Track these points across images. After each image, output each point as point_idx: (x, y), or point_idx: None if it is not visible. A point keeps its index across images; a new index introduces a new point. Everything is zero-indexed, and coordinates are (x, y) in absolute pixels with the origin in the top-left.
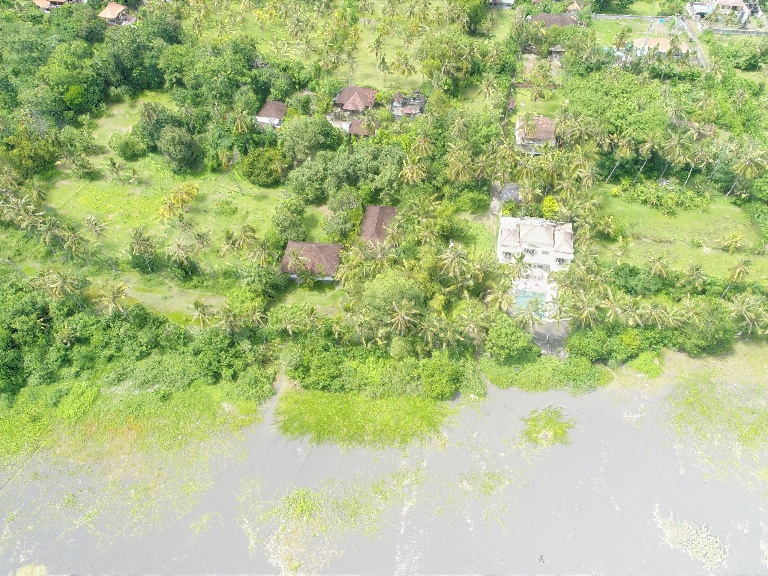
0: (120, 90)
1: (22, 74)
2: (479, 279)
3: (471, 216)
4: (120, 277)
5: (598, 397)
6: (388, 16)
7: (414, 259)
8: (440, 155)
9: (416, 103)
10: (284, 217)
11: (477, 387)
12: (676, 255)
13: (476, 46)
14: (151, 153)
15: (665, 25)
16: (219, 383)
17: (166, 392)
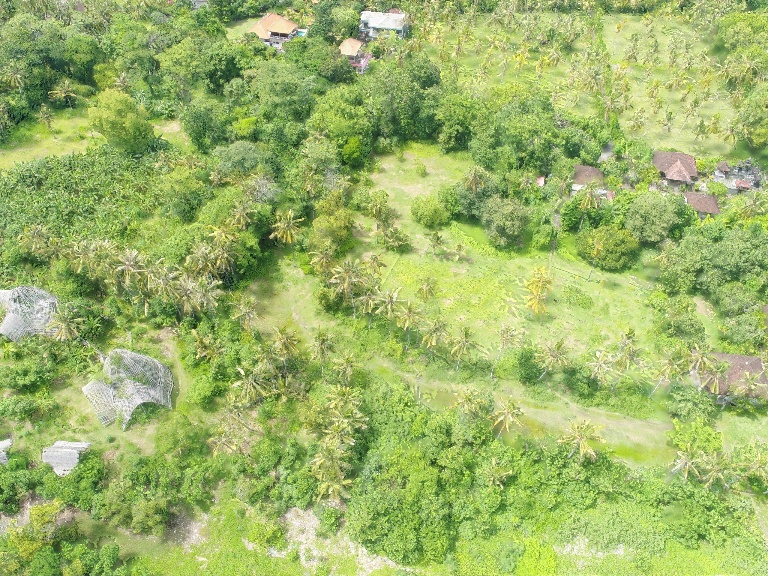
0: (389, 141)
1: (278, 119)
2: None
3: None
4: (499, 386)
5: None
6: None
7: None
8: None
9: (741, 174)
10: (691, 322)
11: None
12: None
13: None
14: (454, 221)
15: None
16: (700, 546)
17: None
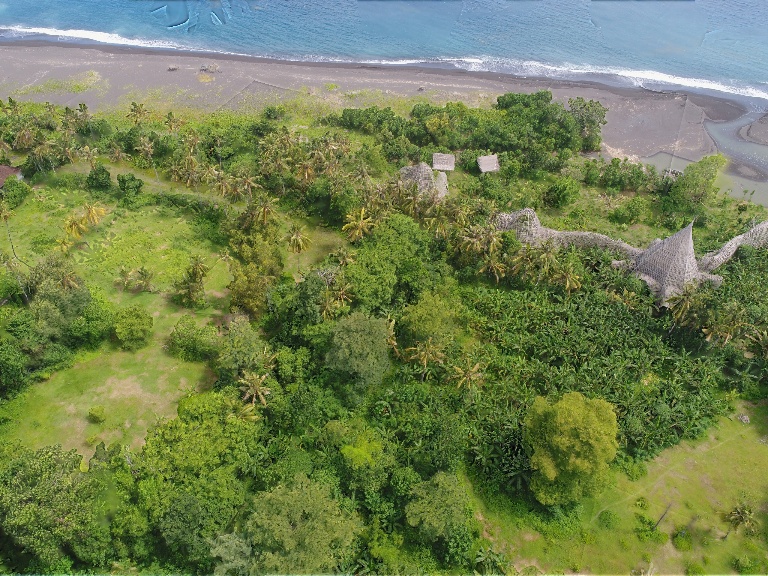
0: None
1: None
2: None
3: None
4: None
5: None
6: None
7: None
8: None
9: None
10: None
11: None
12: None
13: None
14: None
15: None
16: None
17: None
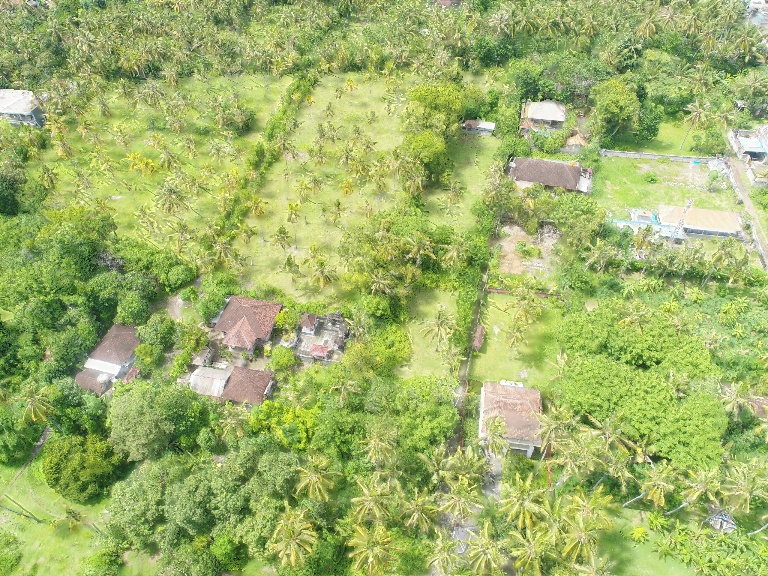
0: None
1: None
2: None
3: None
4: None
5: None
6: None
7: None
8: None
9: (336, 328)
10: None
11: None
12: None
13: None
14: None
15: (701, 170)
16: None
17: None
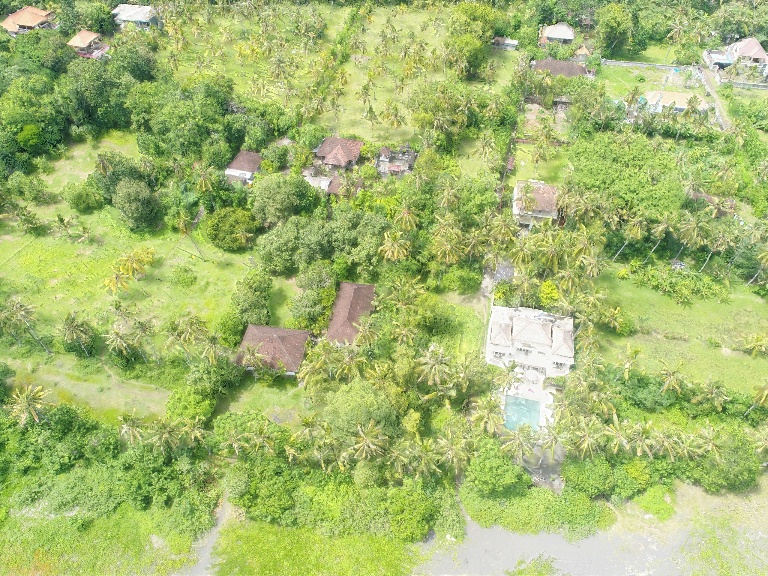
0: (82, 129)
1: None
2: (463, 388)
3: (459, 297)
4: (53, 360)
5: (598, 545)
6: (380, 56)
7: (389, 359)
8: (428, 223)
9: (405, 158)
10: (244, 297)
11: (454, 527)
12: (691, 356)
13: (474, 95)
14: (108, 205)
15: (680, 75)
16: (150, 508)
17: (85, 520)
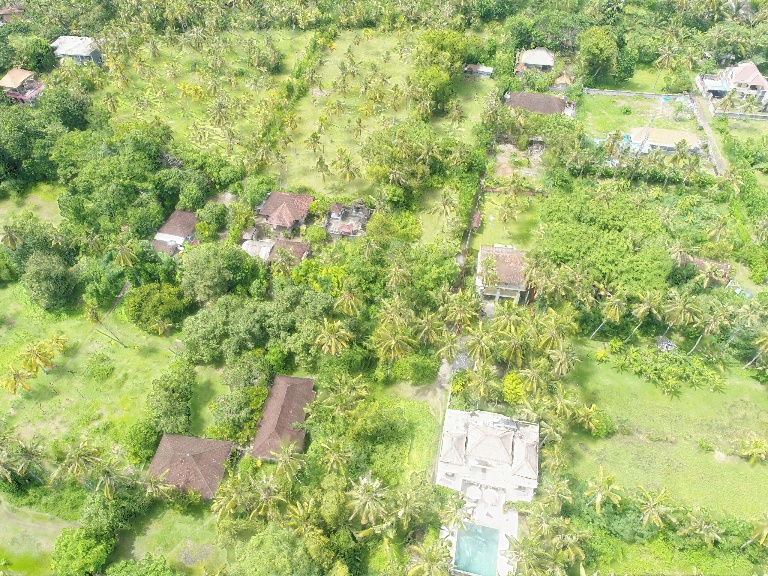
0: (5, 185)
1: None
2: None
3: (412, 389)
4: None
5: None
6: (338, 93)
7: (318, 487)
8: (379, 297)
9: (359, 215)
10: (157, 404)
11: None
12: (678, 464)
13: None
14: None
15: (670, 105)
16: None
17: None
